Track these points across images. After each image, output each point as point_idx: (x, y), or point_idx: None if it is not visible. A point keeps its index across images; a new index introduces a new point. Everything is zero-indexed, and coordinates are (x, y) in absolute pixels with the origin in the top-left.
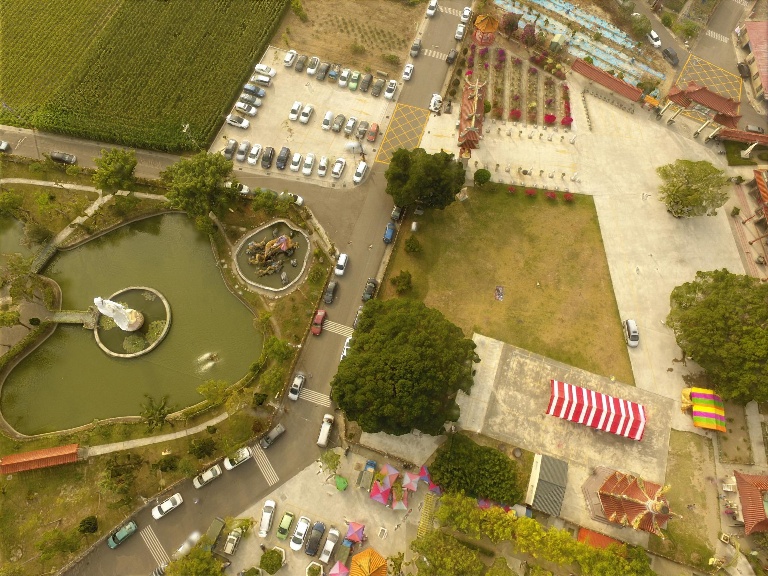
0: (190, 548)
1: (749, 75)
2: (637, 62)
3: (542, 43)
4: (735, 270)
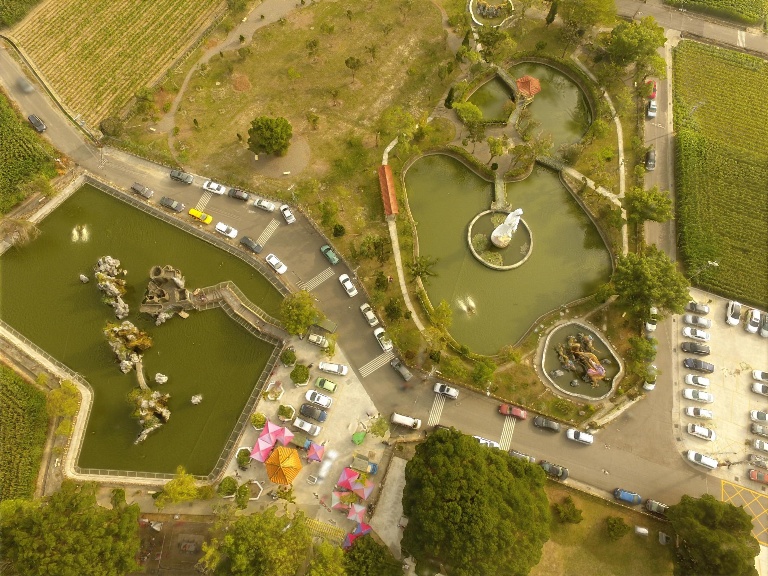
0: (316, 306)
1: None
2: None
3: None
4: None
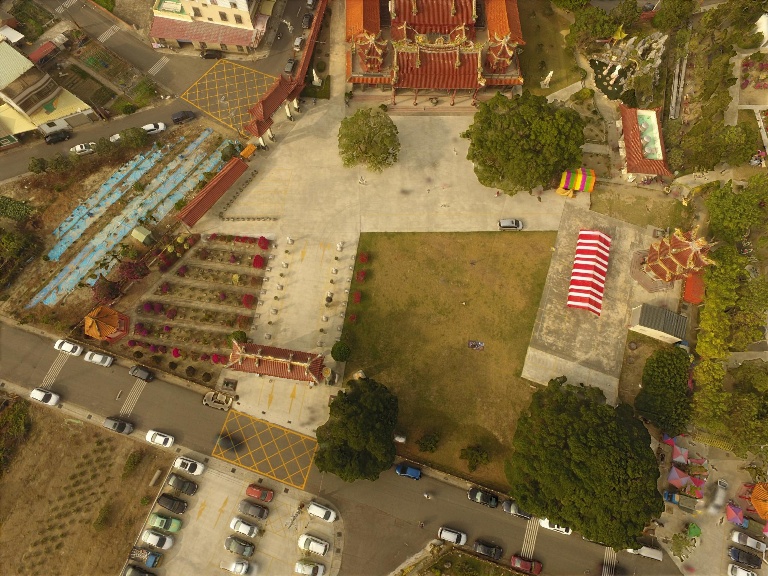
0: None
1: (219, 52)
2: (183, 153)
3: (139, 254)
4: (442, 124)
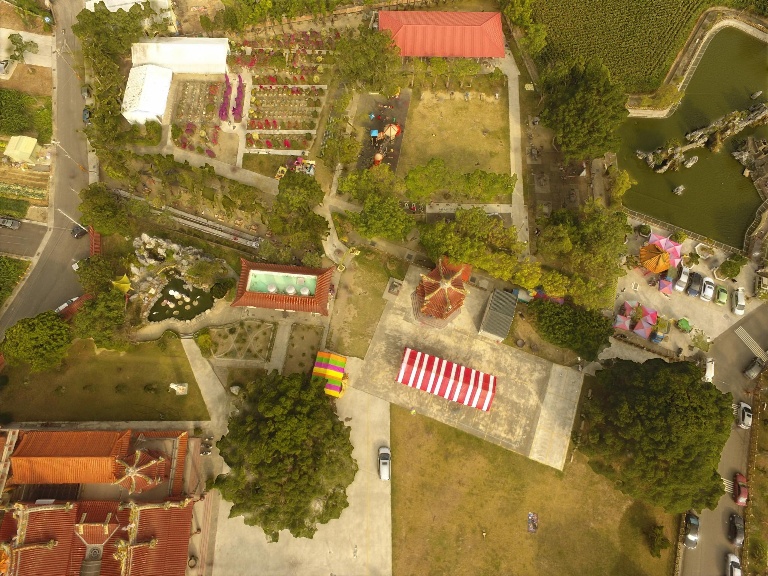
0: None
1: None
2: None
3: None
4: (227, 548)
